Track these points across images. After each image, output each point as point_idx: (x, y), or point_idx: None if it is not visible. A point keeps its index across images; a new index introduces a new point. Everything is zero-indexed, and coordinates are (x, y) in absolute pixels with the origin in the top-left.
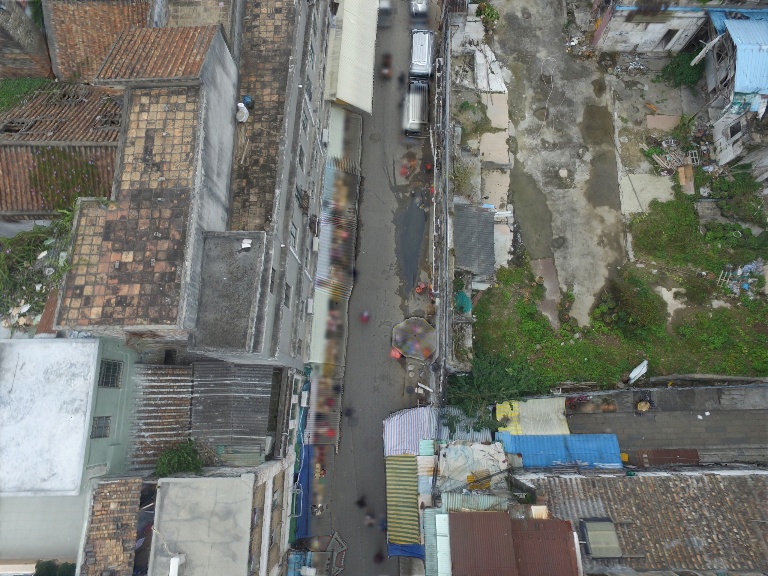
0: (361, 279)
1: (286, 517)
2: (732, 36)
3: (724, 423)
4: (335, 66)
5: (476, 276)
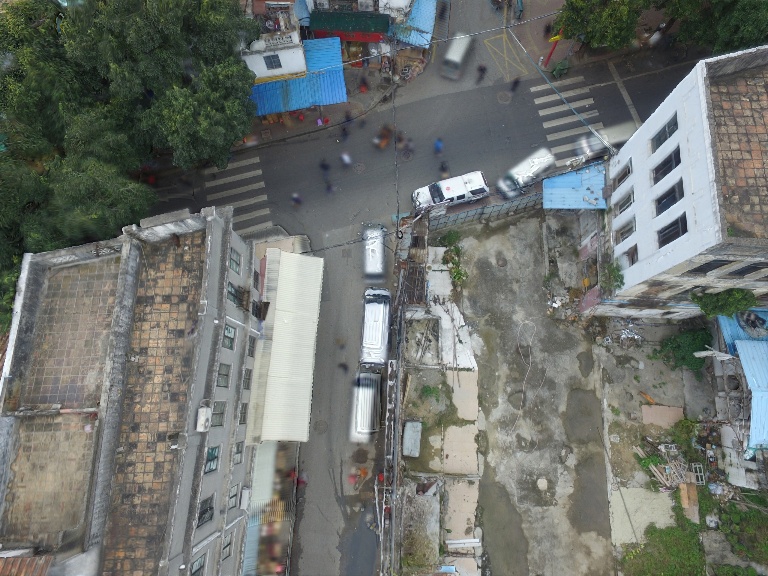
0: None
1: None
2: (746, 373)
3: None
4: (261, 396)
5: None
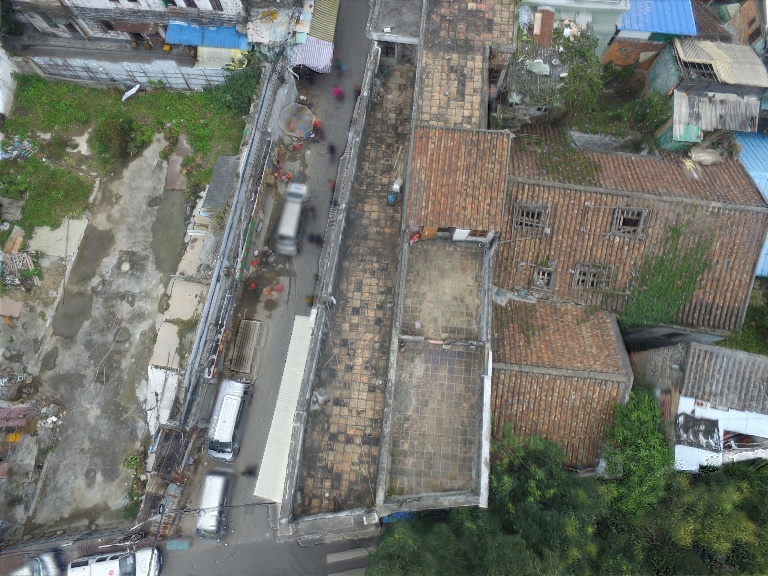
0: None
1: None
2: None
3: (86, 64)
4: None
5: None
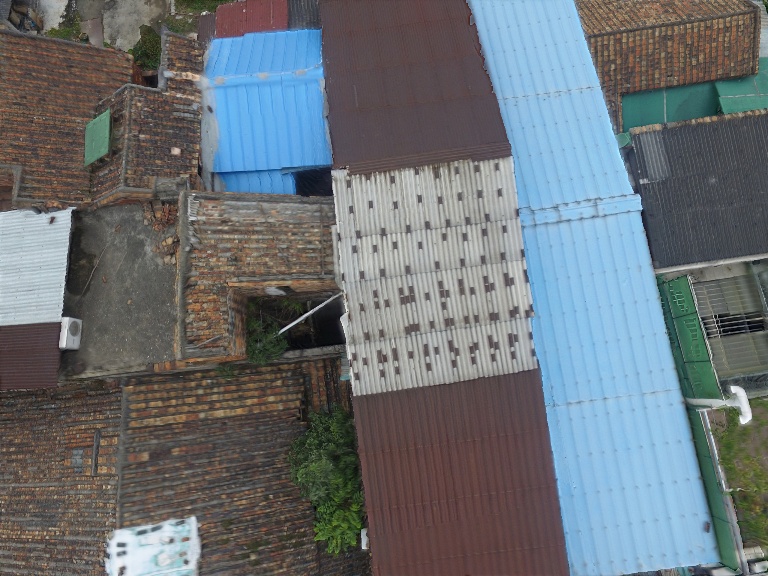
0: None
1: None
2: None
3: None
4: None
5: None
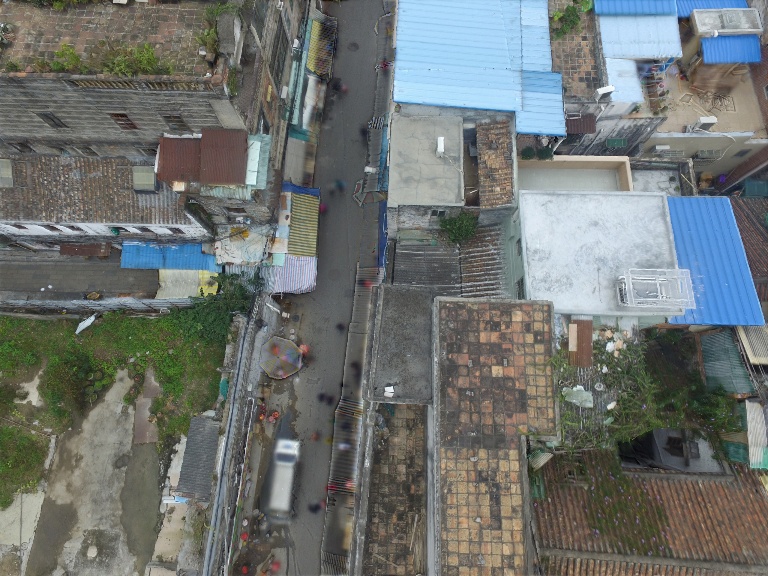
0: None
1: None
2: None
3: (32, 281)
4: None
5: None
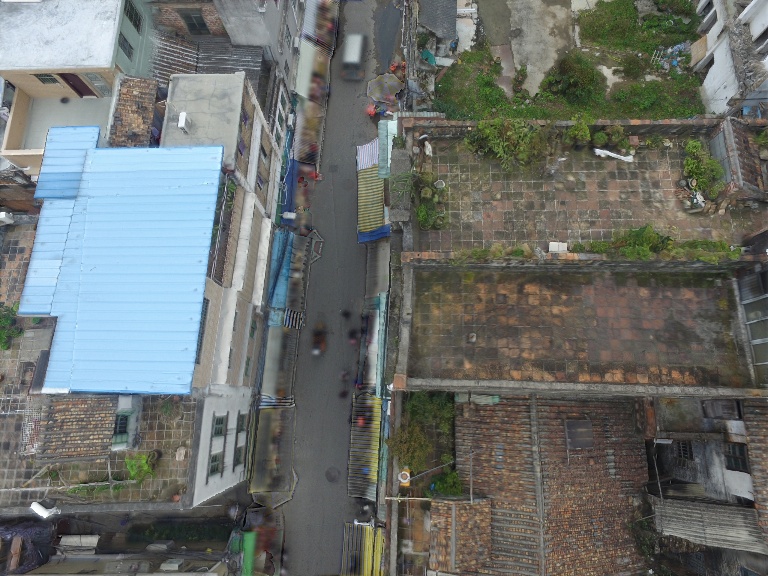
0: (343, 62)
1: (273, 196)
2: None
3: None
4: None
5: (441, 44)
